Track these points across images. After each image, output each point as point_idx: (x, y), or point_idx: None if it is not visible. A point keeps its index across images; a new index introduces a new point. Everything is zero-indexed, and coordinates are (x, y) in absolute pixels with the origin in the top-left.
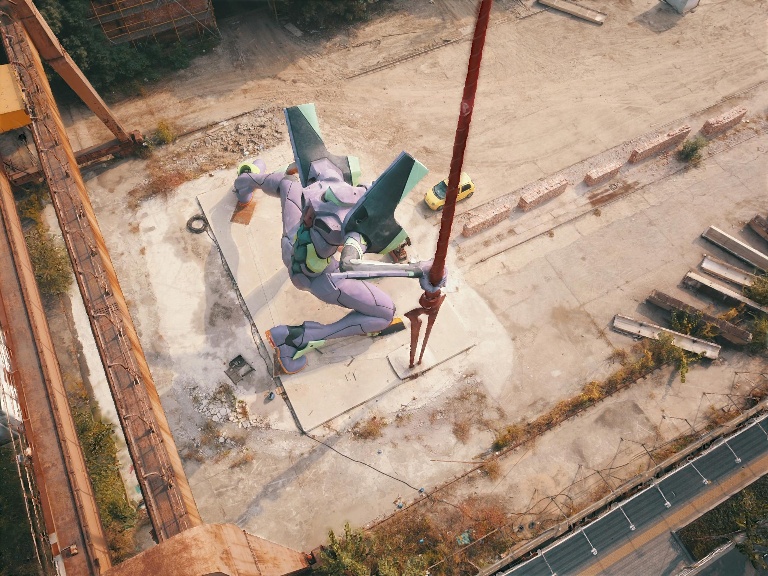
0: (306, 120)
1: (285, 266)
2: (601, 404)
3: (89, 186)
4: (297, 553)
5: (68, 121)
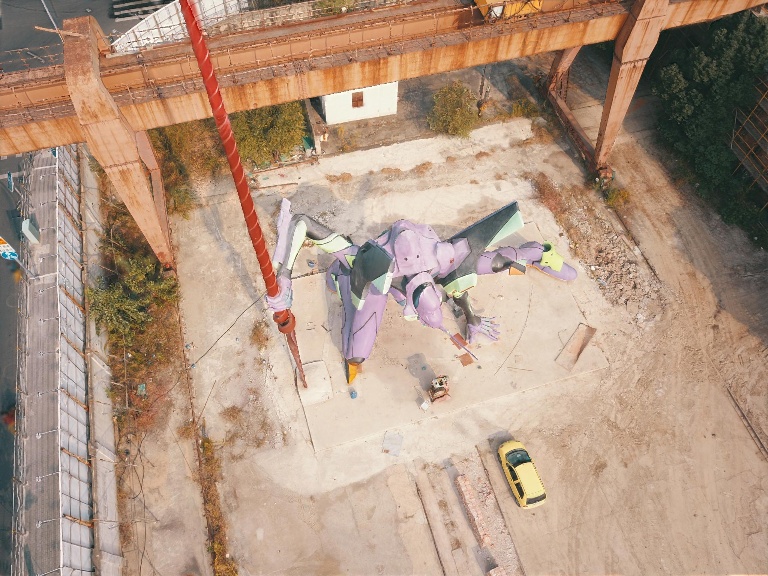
0: (506, 223)
1: (441, 287)
2: (210, 574)
3: (552, 146)
4: (167, 251)
5: (633, 129)
